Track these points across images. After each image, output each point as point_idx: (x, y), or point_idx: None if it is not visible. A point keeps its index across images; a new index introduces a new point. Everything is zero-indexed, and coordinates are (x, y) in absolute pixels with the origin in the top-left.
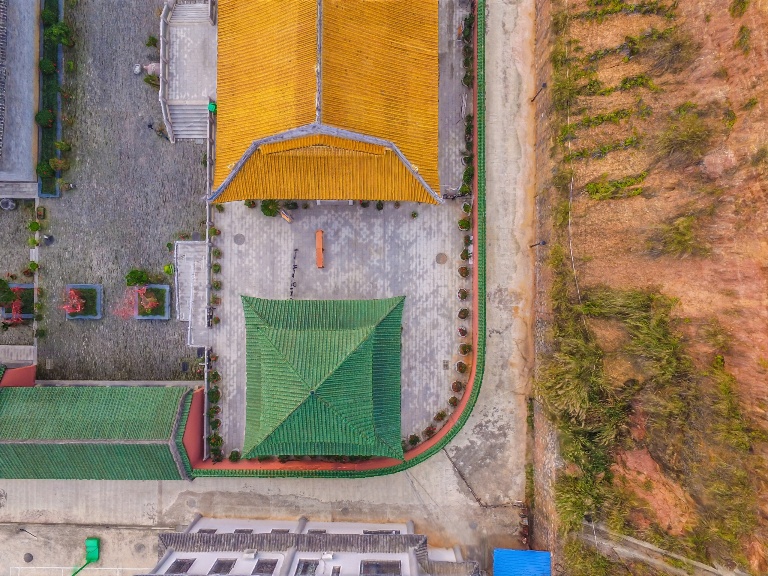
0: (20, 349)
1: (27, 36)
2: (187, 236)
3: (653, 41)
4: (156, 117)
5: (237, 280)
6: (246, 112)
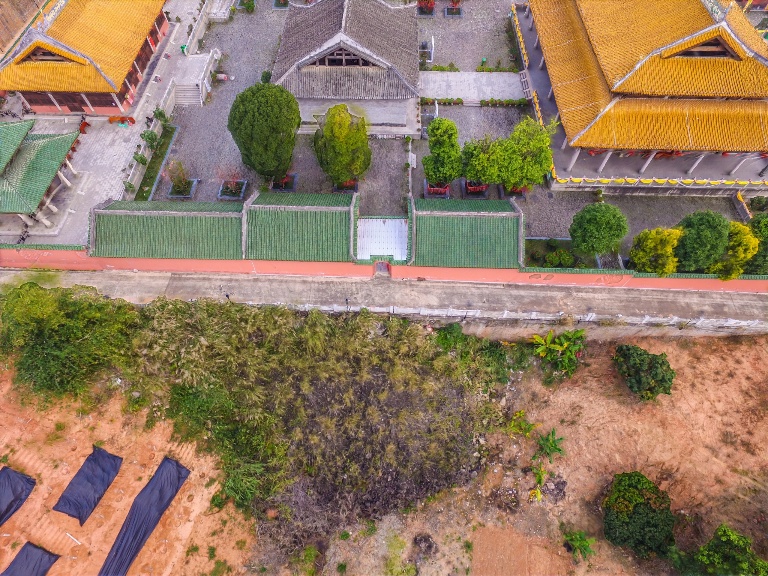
0: None
1: None
2: (223, 23)
3: None
4: (228, 62)
5: (196, 2)
6: None
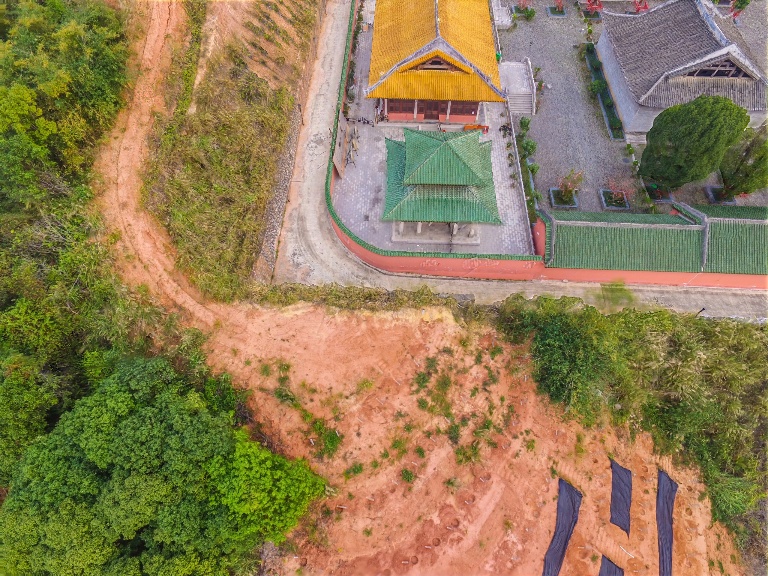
0: (586, 2)
1: (616, 89)
2: (508, 31)
3: (268, 2)
4: None
5: None
6: (473, 6)
